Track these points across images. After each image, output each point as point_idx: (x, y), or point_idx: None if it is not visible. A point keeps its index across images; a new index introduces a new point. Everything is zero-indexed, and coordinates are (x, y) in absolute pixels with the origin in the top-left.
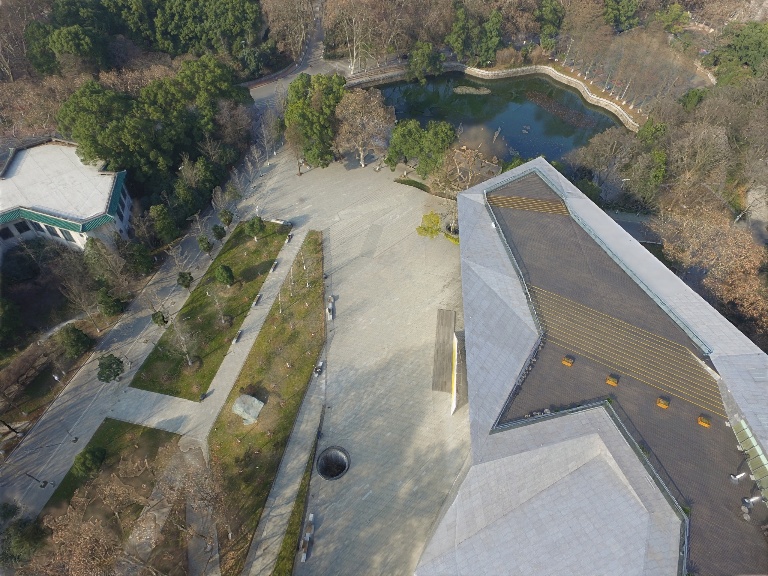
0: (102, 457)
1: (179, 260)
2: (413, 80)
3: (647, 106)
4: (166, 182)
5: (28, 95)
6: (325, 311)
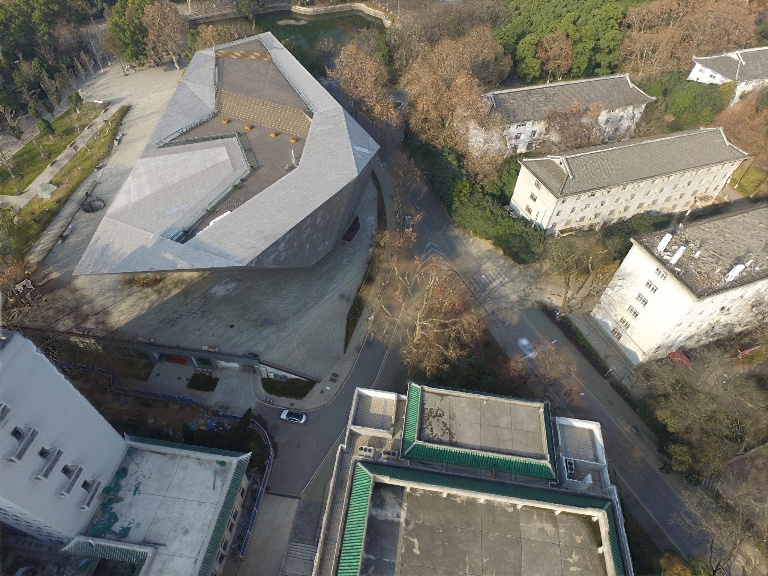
0: None
1: None
2: (244, 16)
3: None
4: (10, 77)
5: None
6: (114, 141)
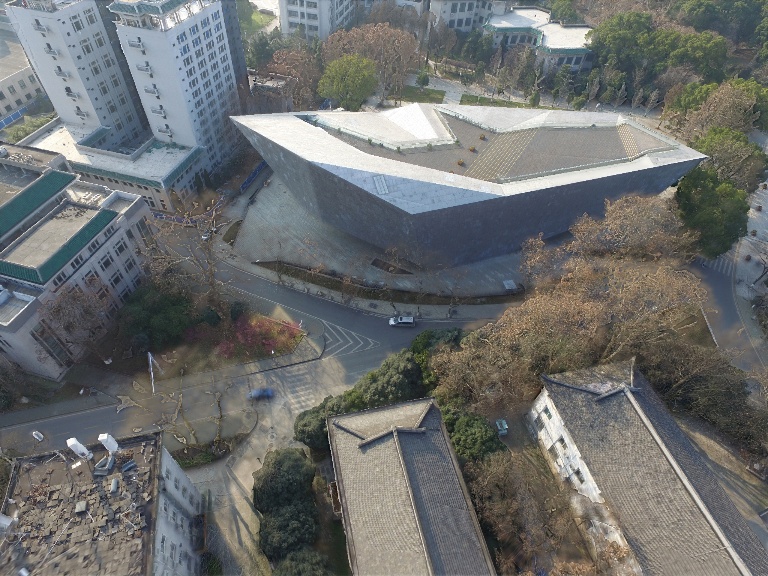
0: (425, 81)
1: (547, 97)
2: None
3: None
4: None
5: (618, 4)
6: None
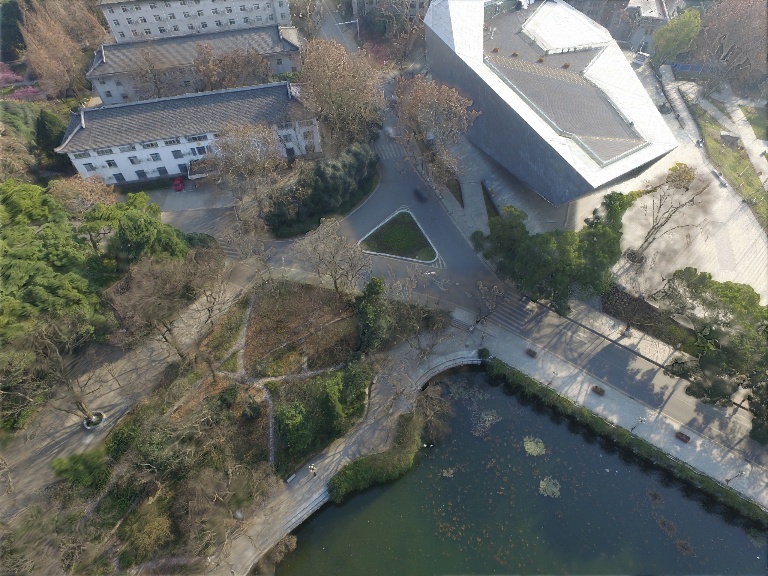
0: None
1: None
2: None
3: (233, 575)
4: None
5: None
6: None
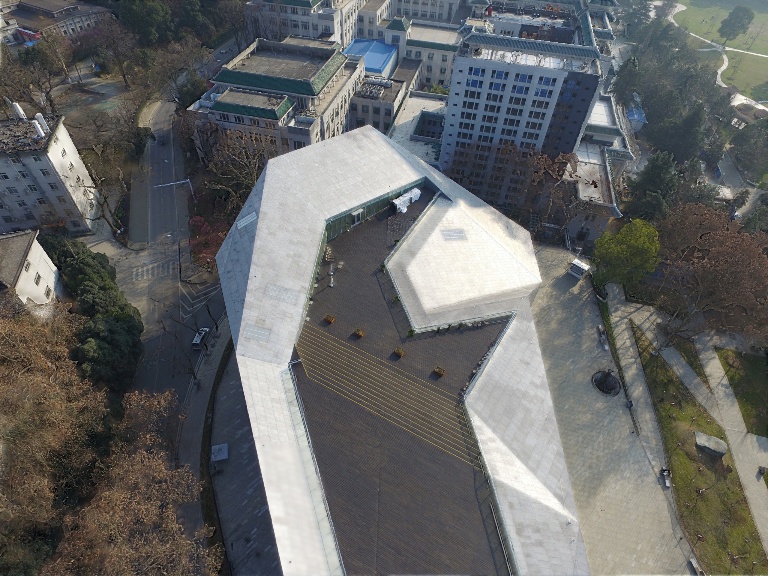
0: None
1: None
2: None
3: None
4: None
5: None
6: None
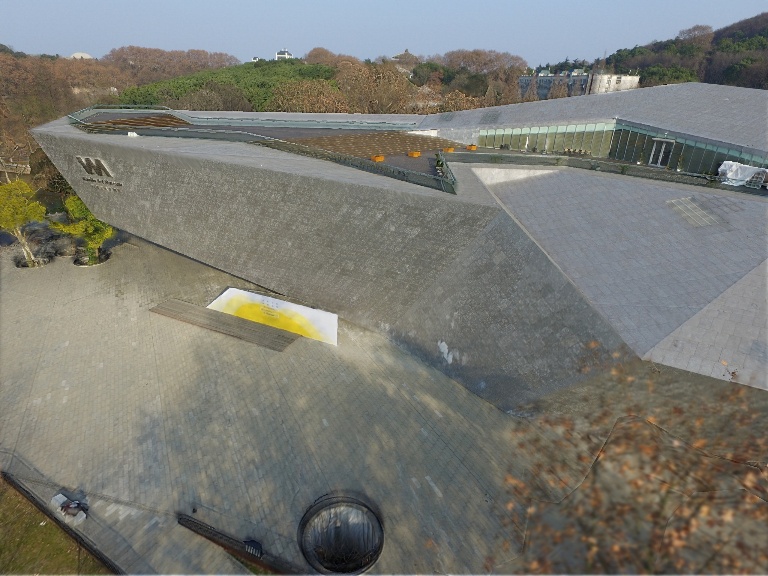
0: None
1: None
2: None
3: None
4: None
5: None
6: None
